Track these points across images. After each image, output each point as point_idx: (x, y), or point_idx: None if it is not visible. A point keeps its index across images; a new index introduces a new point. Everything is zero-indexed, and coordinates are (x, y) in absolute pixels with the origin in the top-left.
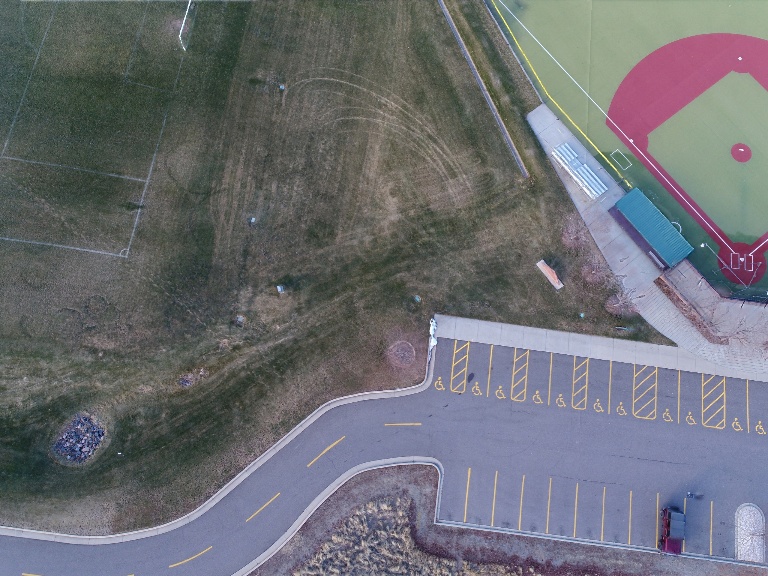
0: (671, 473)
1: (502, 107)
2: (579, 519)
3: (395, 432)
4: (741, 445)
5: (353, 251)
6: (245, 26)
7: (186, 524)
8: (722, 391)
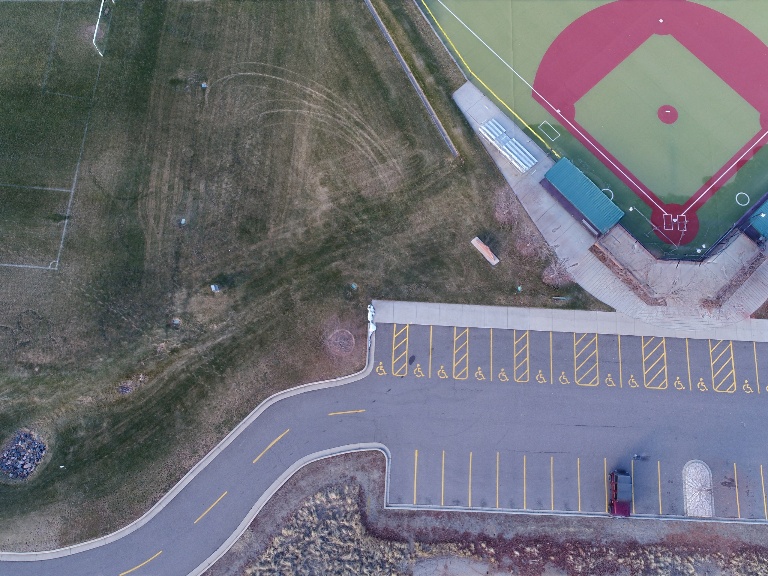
0: (617, 437)
1: (427, 88)
2: (528, 491)
3: (339, 421)
4: (684, 403)
5: (286, 244)
6: (162, 27)
7: (134, 531)
8: (662, 352)
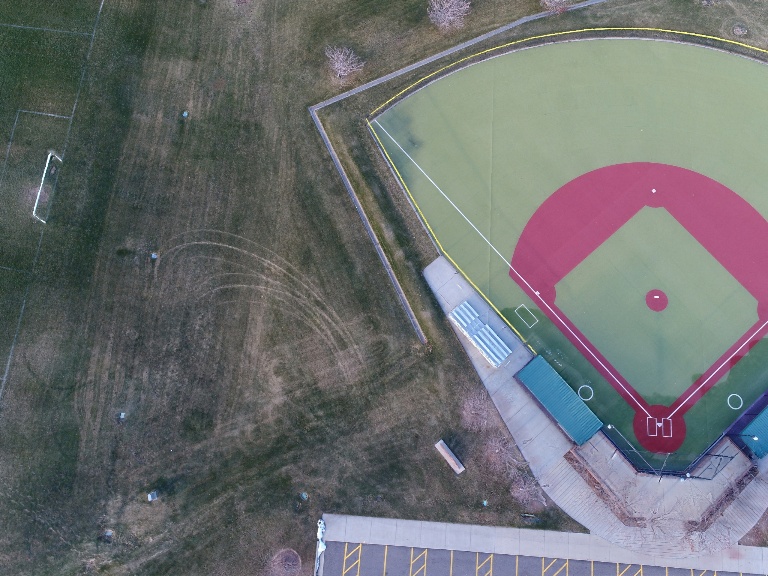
0: None
1: (396, 263)
2: None
3: None
4: None
5: (233, 443)
6: (112, 189)
7: None
8: None
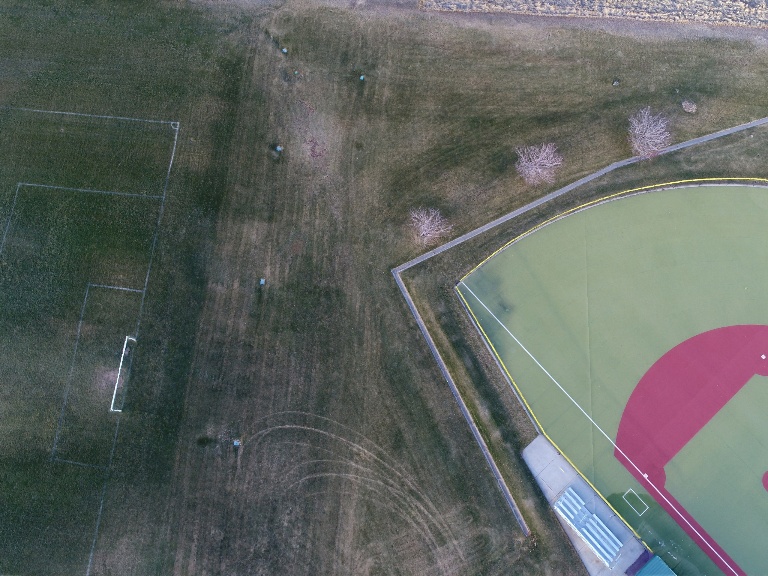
0: None
1: (493, 445)
2: None
3: None
4: None
5: None
6: (189, 370)
7: None
8: None
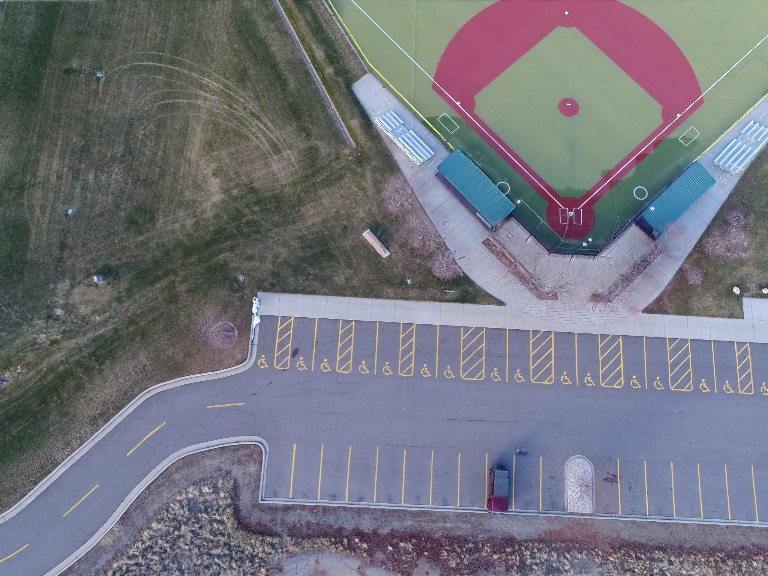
0: (500, 432)
1: (326, 79)
2: (407, 485)
3: (217, 414)
4: (570, 398)
5: (175, 235)
6: (58, 15)
7: (1, 524)
8: (550, 346)
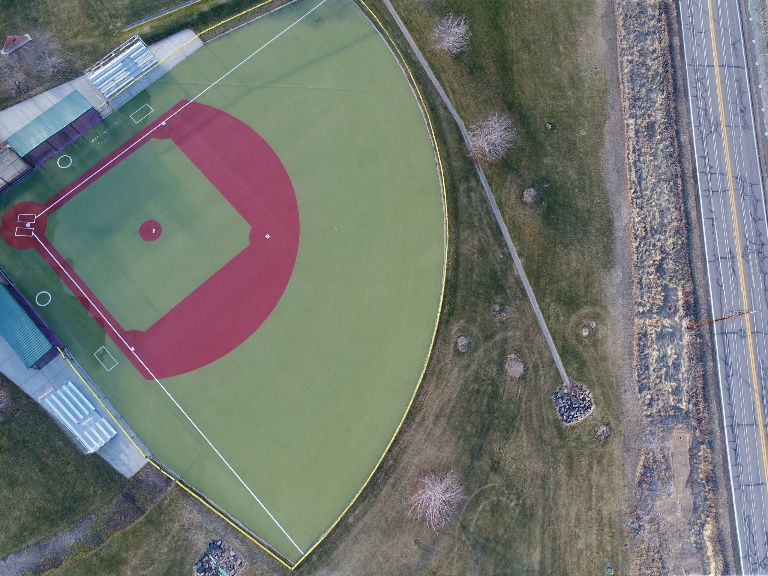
0: None
1: (196, 5)
2: None
3: None
4: None
5: None
6: None
7: None
8: None
